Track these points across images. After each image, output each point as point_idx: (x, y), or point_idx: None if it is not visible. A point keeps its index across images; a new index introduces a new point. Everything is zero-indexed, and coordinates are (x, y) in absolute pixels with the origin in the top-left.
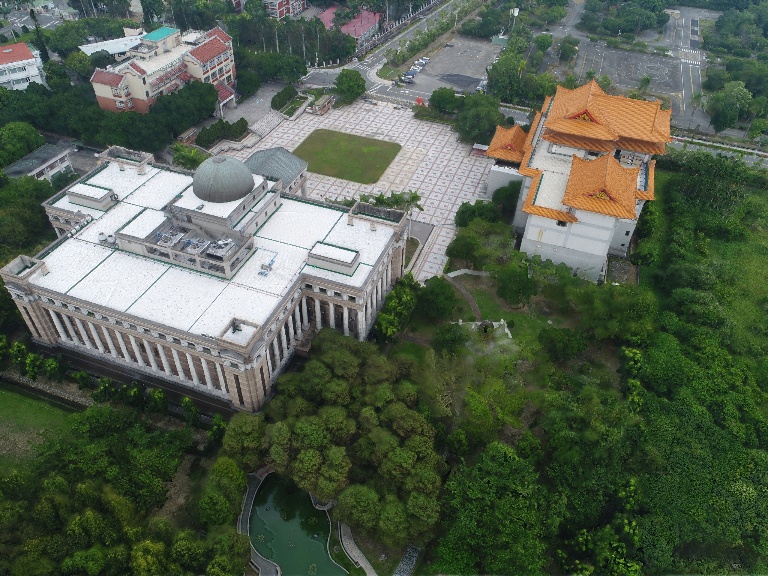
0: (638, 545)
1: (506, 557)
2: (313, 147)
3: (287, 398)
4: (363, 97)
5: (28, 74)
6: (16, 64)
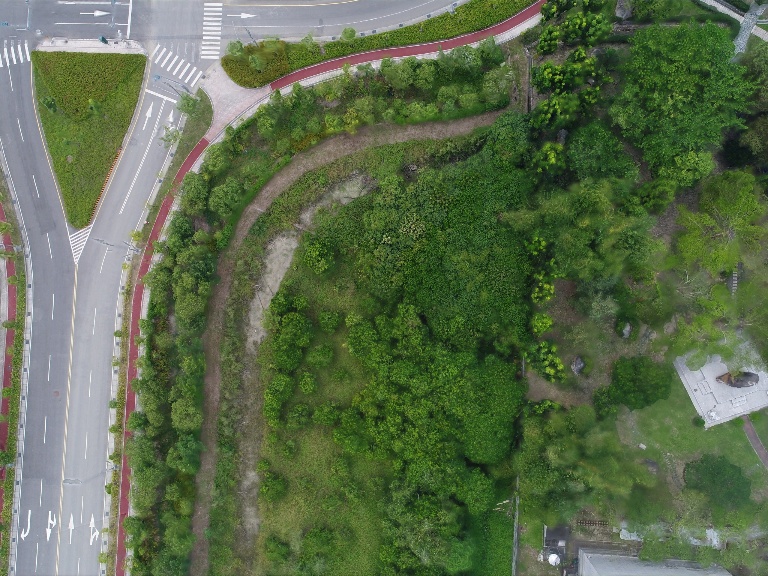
0: (535, 111)
1: (678, 31)
2: None
3: None
4: None
5: None
6: None
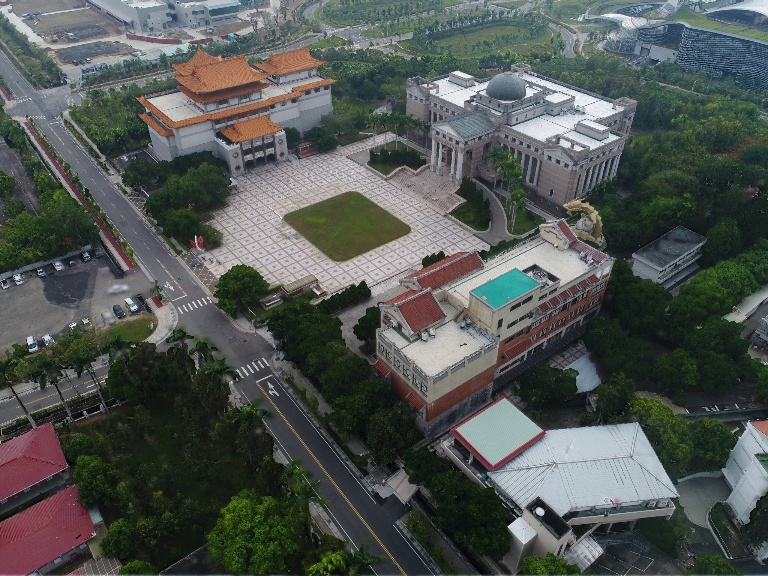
0: None
1: None
2: (367, 239)
3: None
4: None
5: None
6: None
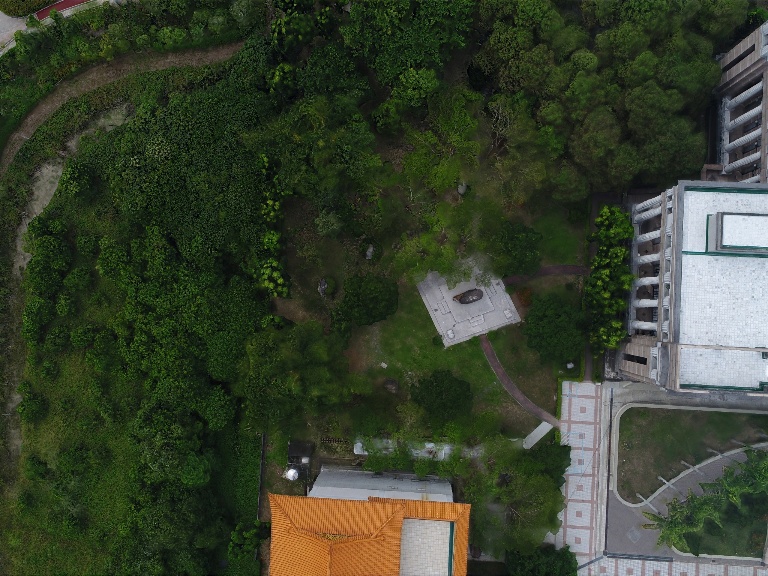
0: None
1: None
2: None
3: (696, 59)
4: None
5: None
6: None
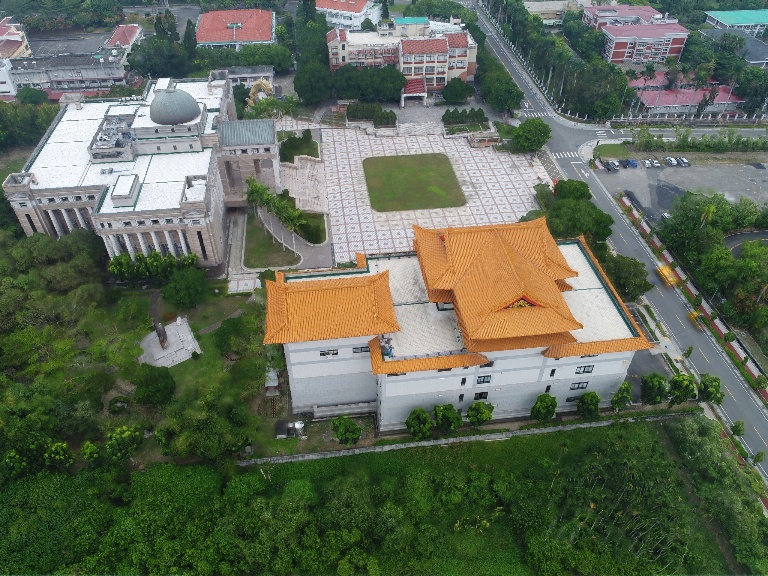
0: None
1: None
2: (407, 162)
3: None
4: (537, 155)
5: (352, 23)
6: (347, 13)
